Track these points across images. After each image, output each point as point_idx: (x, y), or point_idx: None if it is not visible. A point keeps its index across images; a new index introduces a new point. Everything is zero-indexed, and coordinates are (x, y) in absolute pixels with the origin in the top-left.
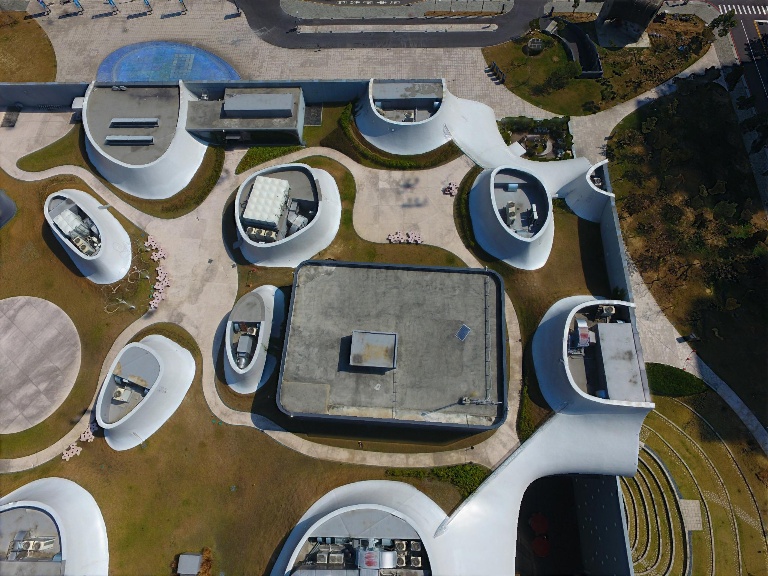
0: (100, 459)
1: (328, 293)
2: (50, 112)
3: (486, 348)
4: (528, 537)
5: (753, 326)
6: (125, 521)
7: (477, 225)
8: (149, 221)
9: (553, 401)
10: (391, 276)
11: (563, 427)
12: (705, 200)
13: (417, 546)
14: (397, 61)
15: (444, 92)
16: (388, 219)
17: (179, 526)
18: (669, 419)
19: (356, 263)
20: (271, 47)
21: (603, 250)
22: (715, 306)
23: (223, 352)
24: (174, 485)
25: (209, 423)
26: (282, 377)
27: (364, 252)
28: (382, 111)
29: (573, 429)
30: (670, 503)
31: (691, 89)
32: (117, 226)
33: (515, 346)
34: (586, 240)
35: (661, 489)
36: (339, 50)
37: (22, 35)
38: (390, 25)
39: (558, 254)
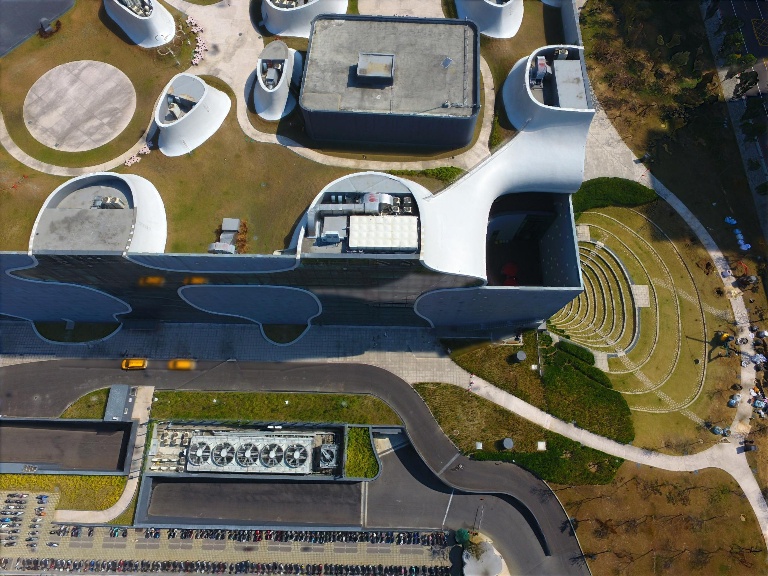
0: (156, 163)
1: (339, 37)
2: None
3: (464, 72)
4: (501, 283)
5: (700, 154)
6: (178, 203)
7: (460, 8)
8: (188, 6)
9: (518, 123)
10: (390, 26)
11: (525, 143)
12: (664, 58)
13: (408, 199)
14: None
15: None
16: (387, 6)
17: (221, 208)
18: (625, 225)
19: (361, 15)
20: None
21: (563, 27)
22: (668, 137)
23: (253, 93)
24: (216, 182)
25: (243, 141)
26: (303, 89)
27: None
28: None
29: (533, 144)
30: (624, 288)
31: None
32: (162, 8)
33: (489, 93)
34: (549, 20)
35: (617, 278)
36: None
37: None
38: None
39: (526, 29)
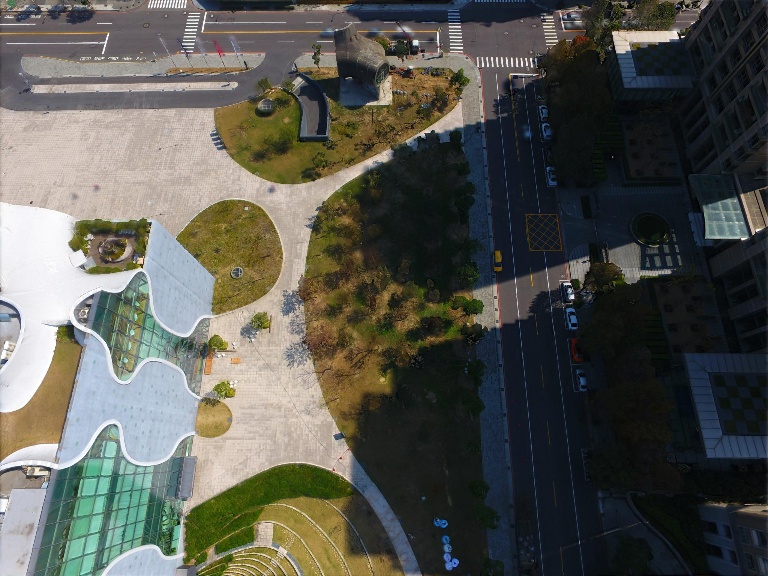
0: None
1: None
2: None
3: None
4: None
5: (425, 417)
6: None
7: None
8: None
9: None
10: None
11: None
12: (407, 276)
13: None
14: (124, 124)
15: None
16: None
17: None
18: (317, 523)
19: None
20: None
21: None
22: (386, 397)
23: None
24: None
25: None
26: None
27: None
28: None
29: None
30: None
31: (403, 156)
32: None
33: None
34: None
35: None
36: (68, 112)
37: None
38: (128, 84)
39: (45, 392)
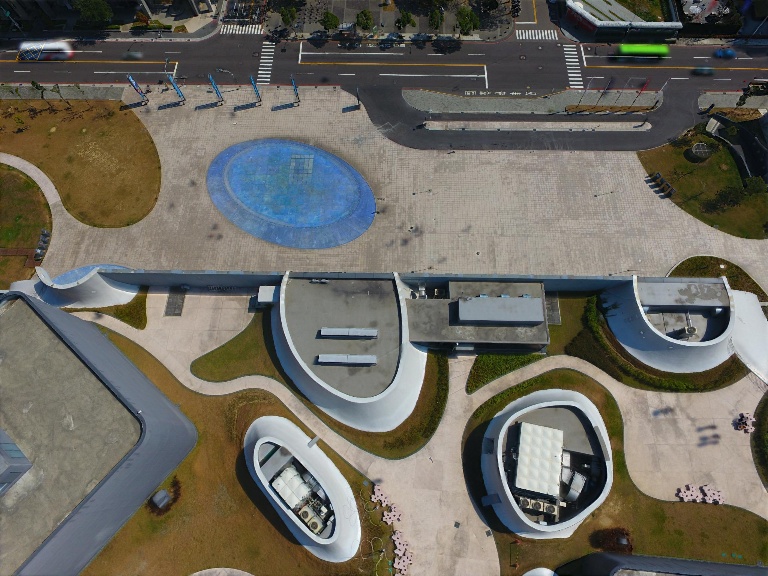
0: None
1: None
2: (222, 295)
3: None
4: None
5: None
6: None
7: None
8: (370, 462)
9: None
10: None
11: None
12: None
13: None
14: (543, 167)
15: (730, 298)
16: (671, 465)
17: None
18: None
19: (687, 572)
20: (398, 147)
21: None
22: None
23: None
24: None
25: None
26: None
27: (649, 514)
28: (649, 318)
29: None
30: None
31: None
32: (334, 472)
33: None
34: None
35: None
36: (476, 152)
37: (119, 129)
38: (529, 122)
39: None
